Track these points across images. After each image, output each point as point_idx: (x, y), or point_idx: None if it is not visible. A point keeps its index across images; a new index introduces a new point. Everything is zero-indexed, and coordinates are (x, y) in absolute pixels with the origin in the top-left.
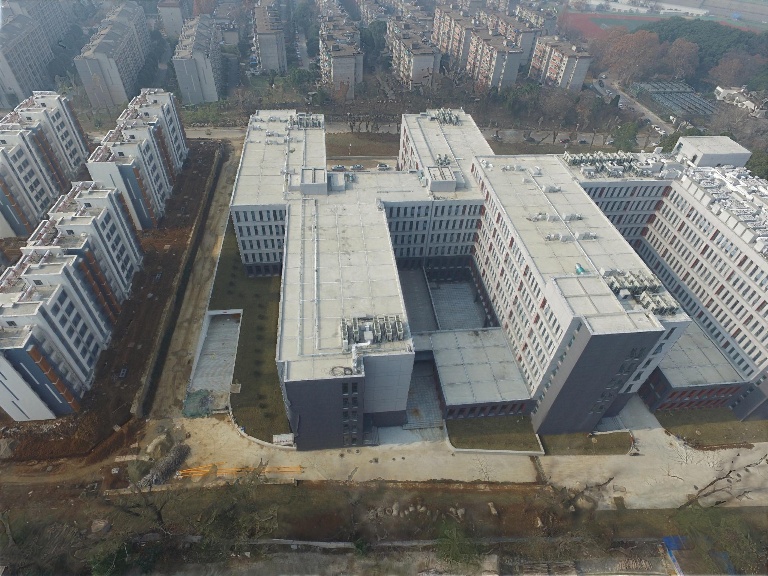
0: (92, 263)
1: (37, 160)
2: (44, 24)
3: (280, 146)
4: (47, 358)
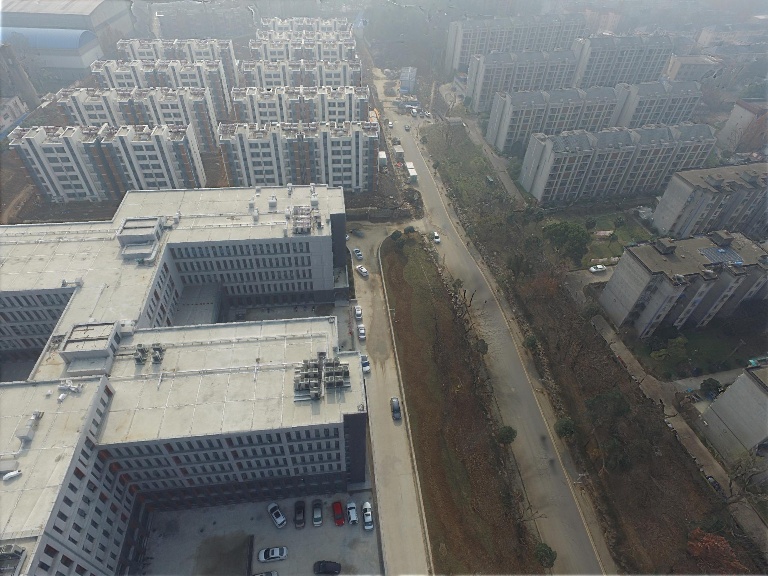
0: (106, 156)
1: (285, 117)
2: (609, 69)
3: (246, 209)
4: (28, 163)
